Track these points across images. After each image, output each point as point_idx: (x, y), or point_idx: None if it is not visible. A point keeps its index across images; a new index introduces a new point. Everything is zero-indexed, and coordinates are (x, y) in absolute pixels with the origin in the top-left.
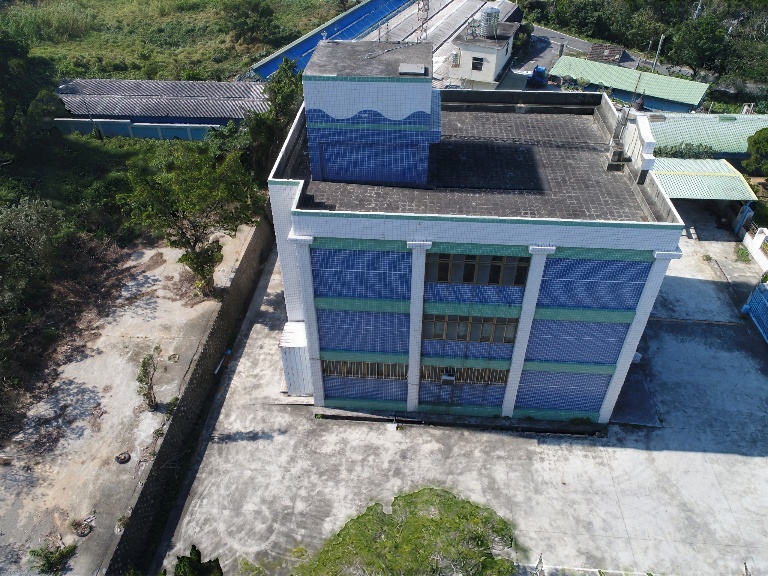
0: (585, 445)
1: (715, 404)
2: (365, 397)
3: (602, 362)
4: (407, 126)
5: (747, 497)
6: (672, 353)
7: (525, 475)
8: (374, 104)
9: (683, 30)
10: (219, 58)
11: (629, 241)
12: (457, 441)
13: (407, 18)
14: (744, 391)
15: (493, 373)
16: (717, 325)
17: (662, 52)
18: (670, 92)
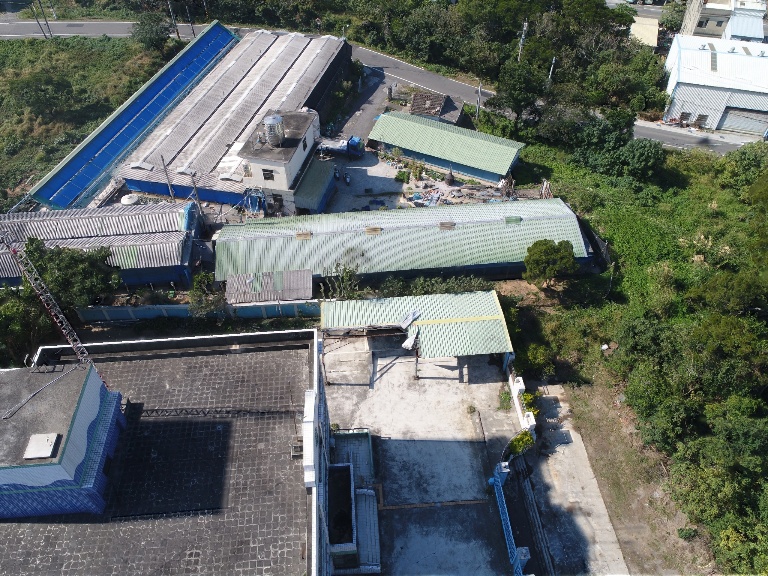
0: None
1: None
2: None
3: None
4: (55, 488)
5: None
6: (414, 553)
7: None
8: (10, 480)
9: (501, 75)
10: (13, 148)
11: None
12: None
13: (221, 77)
14: None
15: None
16: (463, 506)
17: (496, 77)
18: (481, 160)
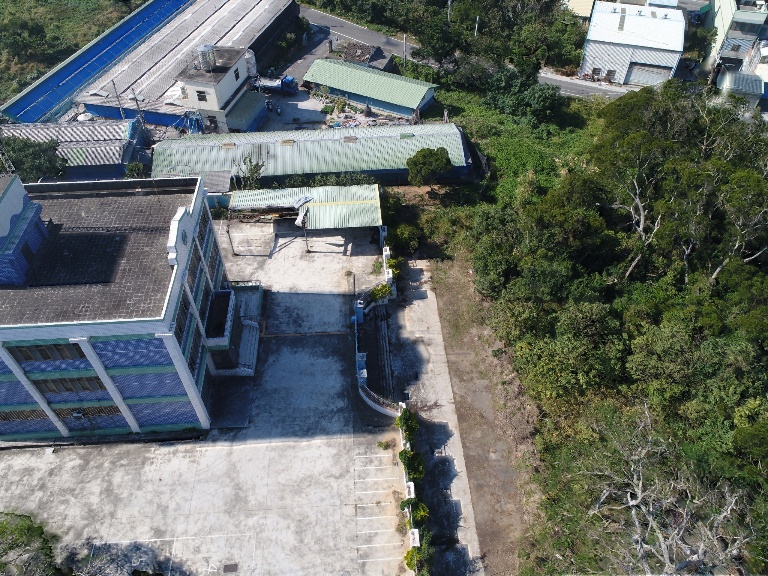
0: (187, 448)
1: (294, 404)
2: (29, 431)
3: (179, 394)
4: None
5: (283, 474)
6: (282, 364)
7: (135, 477)
8: None
9: (424, 28)
10: None
11: (134, 330)
12: (95, 456)
13: (177, 26)
14: (320, 390)
15: (107, 408)
16: (327, 336)
17: None
18: (397, 96)
